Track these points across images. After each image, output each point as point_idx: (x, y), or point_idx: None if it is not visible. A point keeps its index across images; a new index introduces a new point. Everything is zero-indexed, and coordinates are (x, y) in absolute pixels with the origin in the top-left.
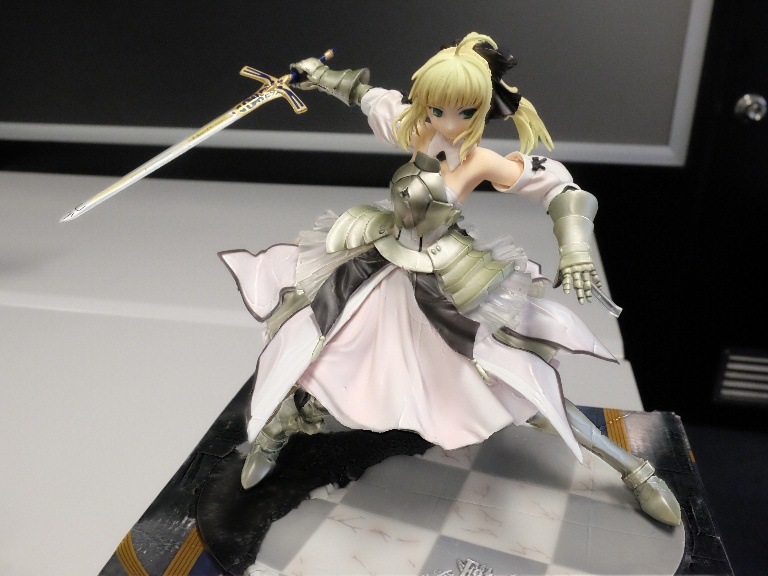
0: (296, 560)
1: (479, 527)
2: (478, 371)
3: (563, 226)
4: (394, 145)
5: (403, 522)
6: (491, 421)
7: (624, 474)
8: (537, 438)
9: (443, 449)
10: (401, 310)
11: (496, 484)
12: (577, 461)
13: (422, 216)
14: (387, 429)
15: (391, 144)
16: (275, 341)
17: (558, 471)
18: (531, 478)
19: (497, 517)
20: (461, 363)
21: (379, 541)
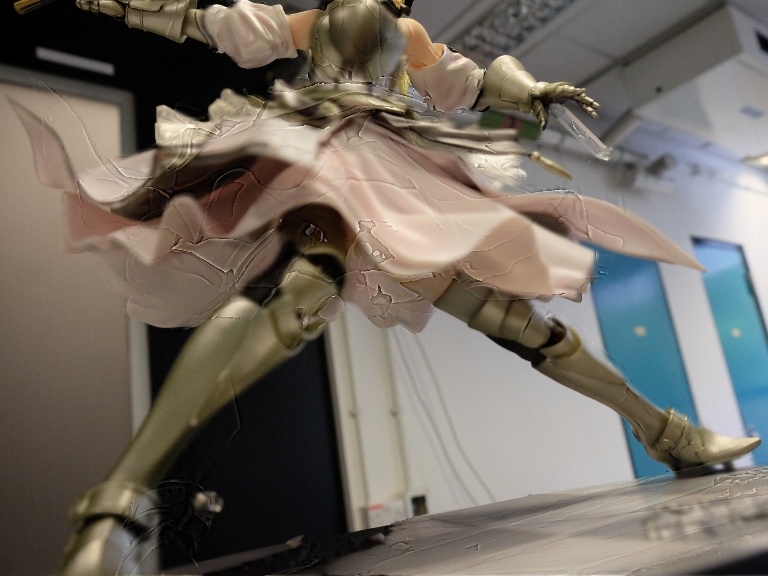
0: (544, 568)
1: (639, 502)
2: (574, 150)
3: (513, 82)
4: (269, 39)
5: (558, 533)
6: (606, 239)
7: (663, 419)
8: (503, 511)
9: (428, 542)
10: (399, 154)
11: (557, 512)
12: (577, 493)
13: (393, 30)
14: (537, 213)
15: (264, 40)
16: (281, 96)
17: (582, 495)
18: (574, 502)
19: (630, 499)
20: (521, 190)
21: (585, 535)
